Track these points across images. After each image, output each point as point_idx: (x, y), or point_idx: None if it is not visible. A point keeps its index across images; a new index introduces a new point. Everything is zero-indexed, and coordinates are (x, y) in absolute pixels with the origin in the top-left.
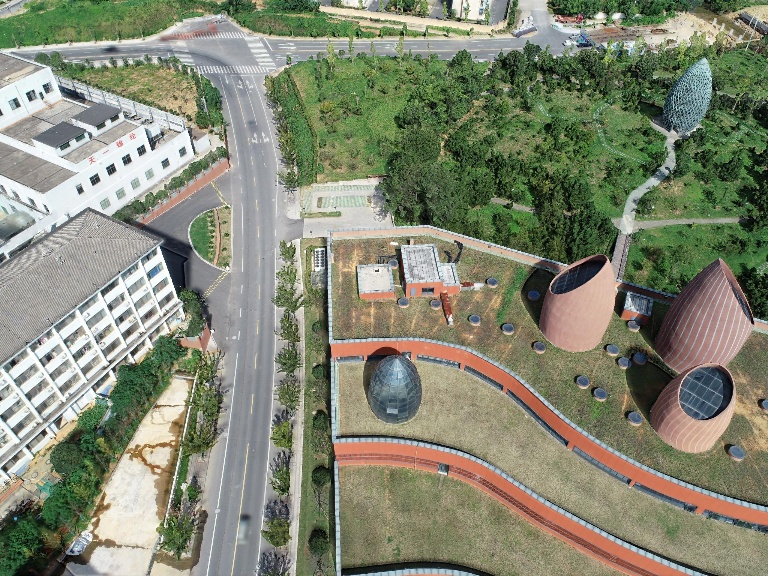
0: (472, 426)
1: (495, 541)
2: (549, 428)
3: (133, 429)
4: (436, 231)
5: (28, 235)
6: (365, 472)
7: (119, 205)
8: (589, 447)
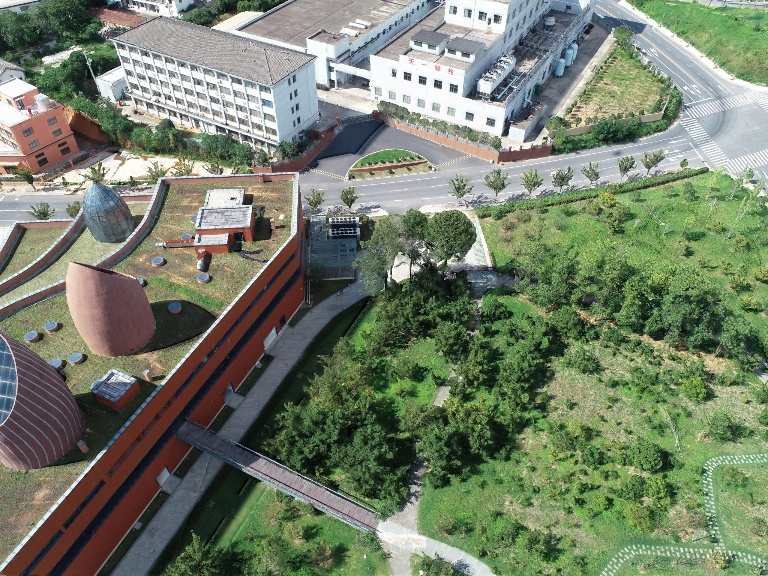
0: None
1: None
2: None
3: (196, 158)
4: None
5: (351, 71)
6: None
7: (416, 110)
8: None
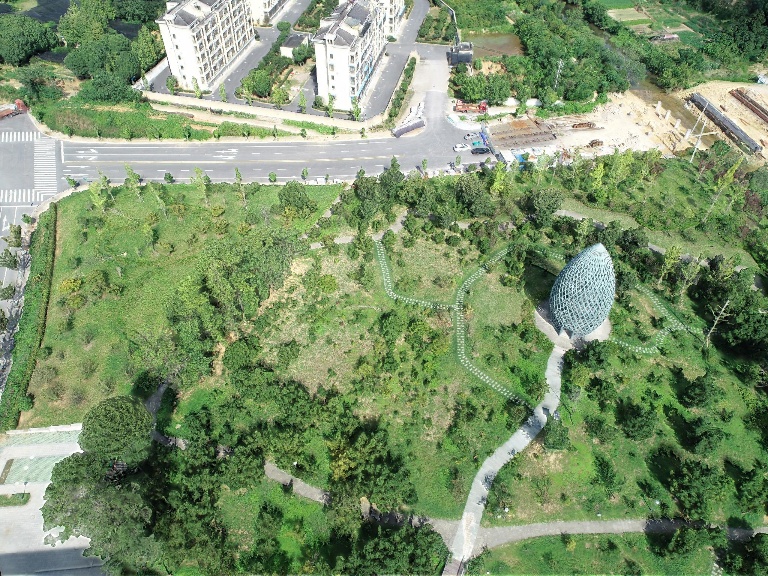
0: None
1: None
2: None
3: None
4: None
5: None
6: None
7: None
8: None
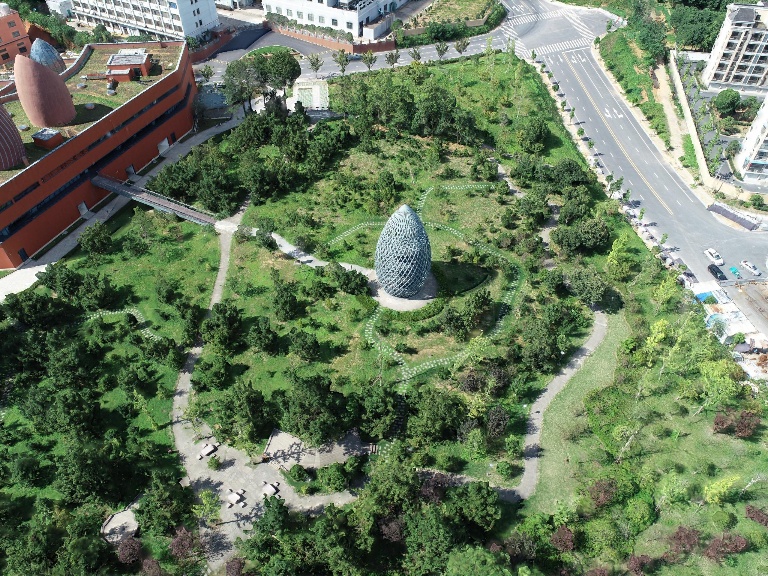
0: None
1: None
2: None
3: None
4: None
5: None
6: None
7: (298, 21)
8: None
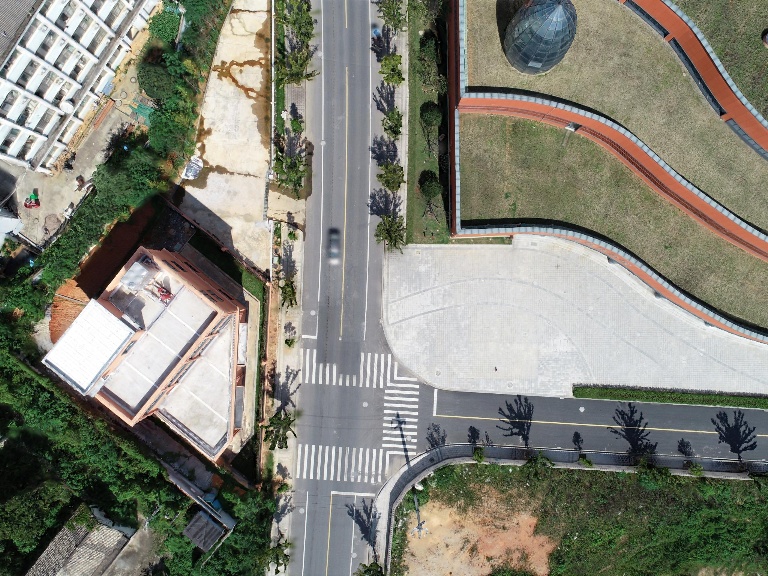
0: (619, 83)
1: (611, 203)
2: (707, 92)
3: (214, 41)
4: None
5: None
6: (486, 122)
7: None
8: (750, 125)
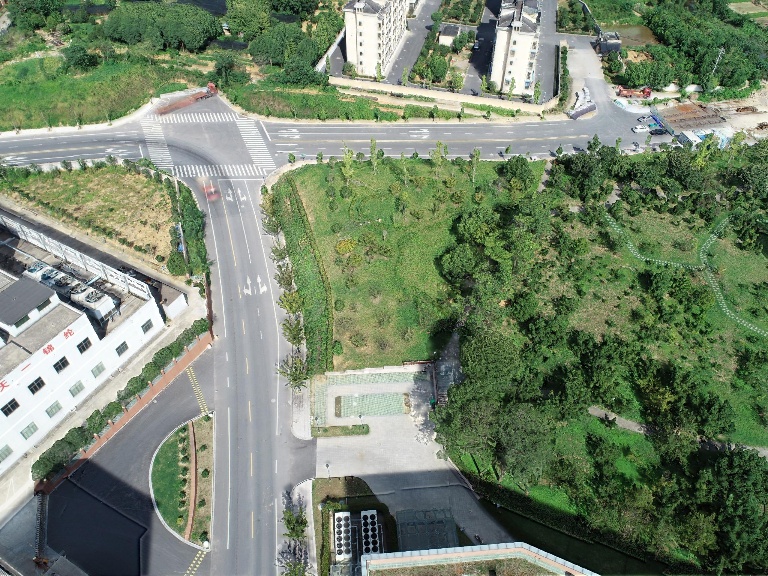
0: None
1: None
2: None
3: None
4: (536, 554)
5: None
6: None
7: (52, 424)
8: None
